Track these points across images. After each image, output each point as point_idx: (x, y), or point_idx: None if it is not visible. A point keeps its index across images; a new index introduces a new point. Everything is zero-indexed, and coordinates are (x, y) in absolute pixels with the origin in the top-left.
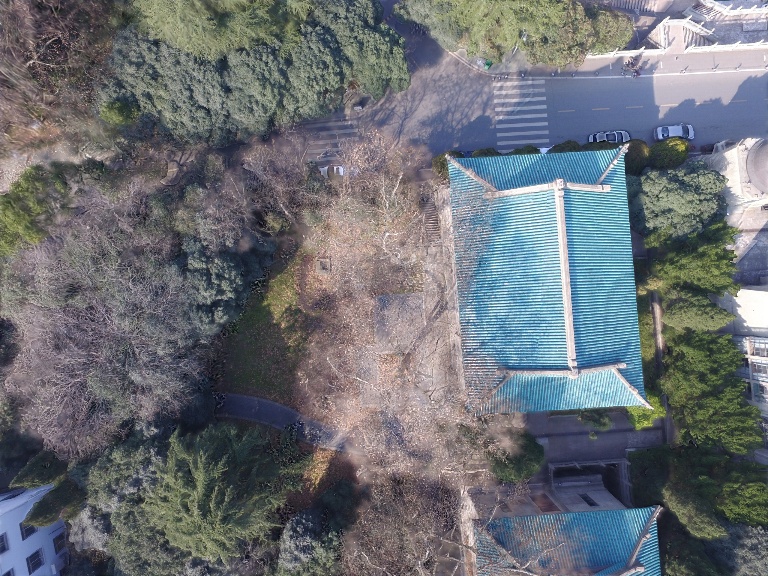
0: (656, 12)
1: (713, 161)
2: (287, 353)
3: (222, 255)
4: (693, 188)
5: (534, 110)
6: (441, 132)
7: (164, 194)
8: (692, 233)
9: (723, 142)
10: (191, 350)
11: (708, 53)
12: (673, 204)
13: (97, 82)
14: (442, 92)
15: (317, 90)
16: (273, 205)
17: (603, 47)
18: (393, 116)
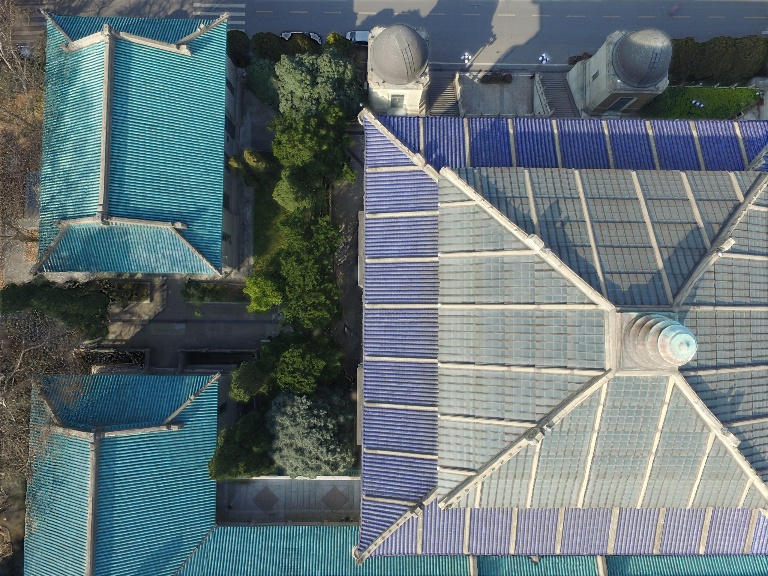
0: None
1: None
2: None
3: None
4: (305, 68)
5: (232, 8)
6: None
7: None
8: (305, 114)
9: None
10: None
11: None
12: (290, 85)
13: None
14: None
15: None
16: None
17: None
18: (91, 4)
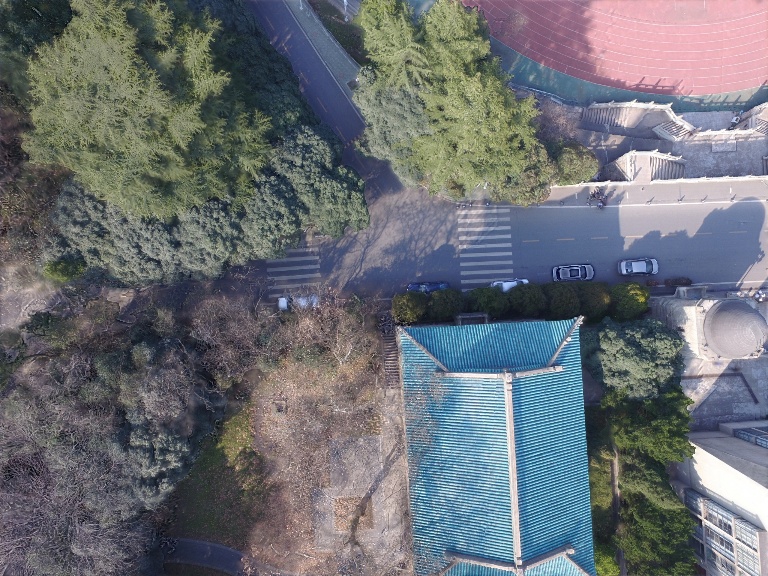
0: (626, 127)
1: (673, 310)
2: (241, 497)
3: (167, 427)
4: (649, 355)
5: (498, 239)
6: (404, 261)
7: (110, 355)
8: (647, 398)
9: (684, 289)
10: (135, 521)
11: (674, 184)
12: (629, 368)
13: (41, 240)
14: (405, 219)
15: (272, 238)
16: (223, 366)
17: (568, 182)
18: (355, 243)
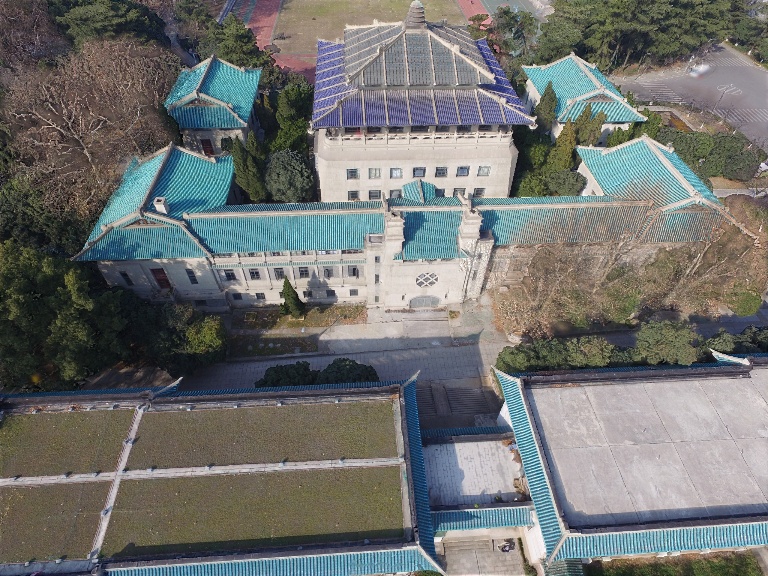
0: None
1: None
2: (82, 154)
3: None
4: None
5: None
6: None
7: None
8: None
9: None
10: None
11: None
12: None
13: None
14: None
15: None
16: None
17: None
18: None
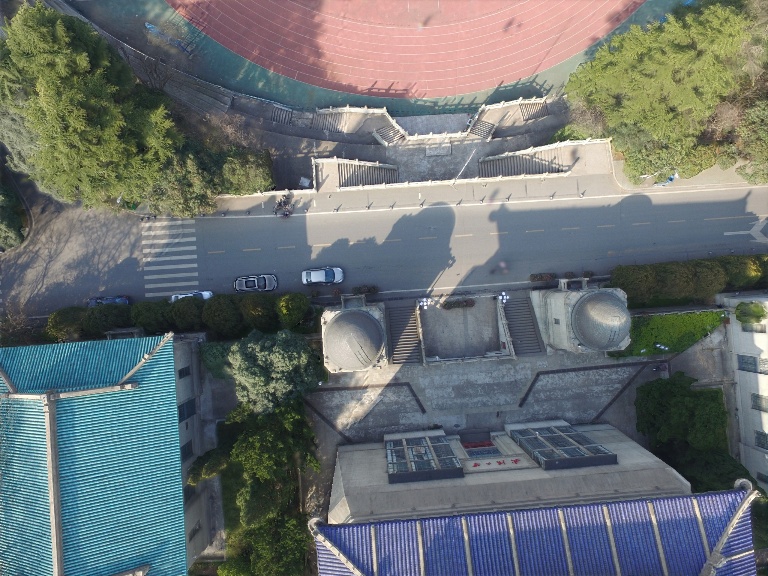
0: (346, 133)
1: None
2: None
3: None
4: (258, 369)
5: (183, 251)
6: (87, 275)
7: None
8: (262, 413)
9: None
10: None
11: (362, 191)
12: None
13: None
14: (88, 233)
15: None
16: None
17: (239, 192)
18: (37, 259)
